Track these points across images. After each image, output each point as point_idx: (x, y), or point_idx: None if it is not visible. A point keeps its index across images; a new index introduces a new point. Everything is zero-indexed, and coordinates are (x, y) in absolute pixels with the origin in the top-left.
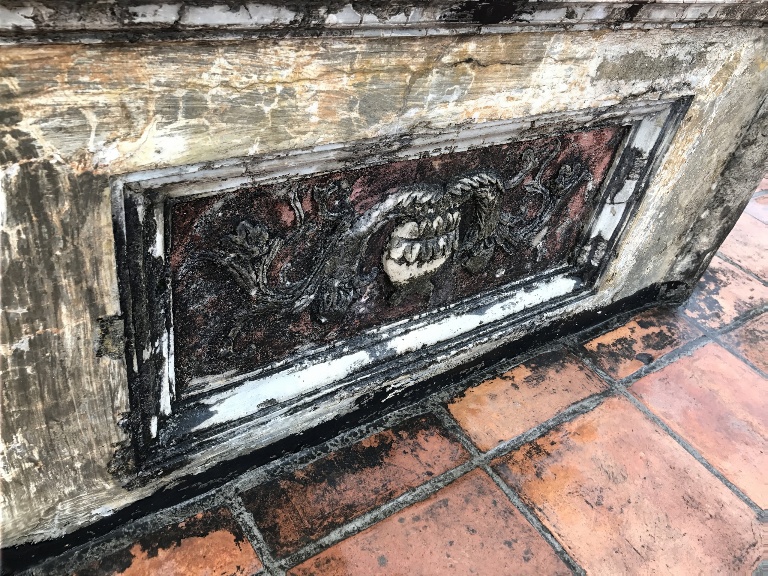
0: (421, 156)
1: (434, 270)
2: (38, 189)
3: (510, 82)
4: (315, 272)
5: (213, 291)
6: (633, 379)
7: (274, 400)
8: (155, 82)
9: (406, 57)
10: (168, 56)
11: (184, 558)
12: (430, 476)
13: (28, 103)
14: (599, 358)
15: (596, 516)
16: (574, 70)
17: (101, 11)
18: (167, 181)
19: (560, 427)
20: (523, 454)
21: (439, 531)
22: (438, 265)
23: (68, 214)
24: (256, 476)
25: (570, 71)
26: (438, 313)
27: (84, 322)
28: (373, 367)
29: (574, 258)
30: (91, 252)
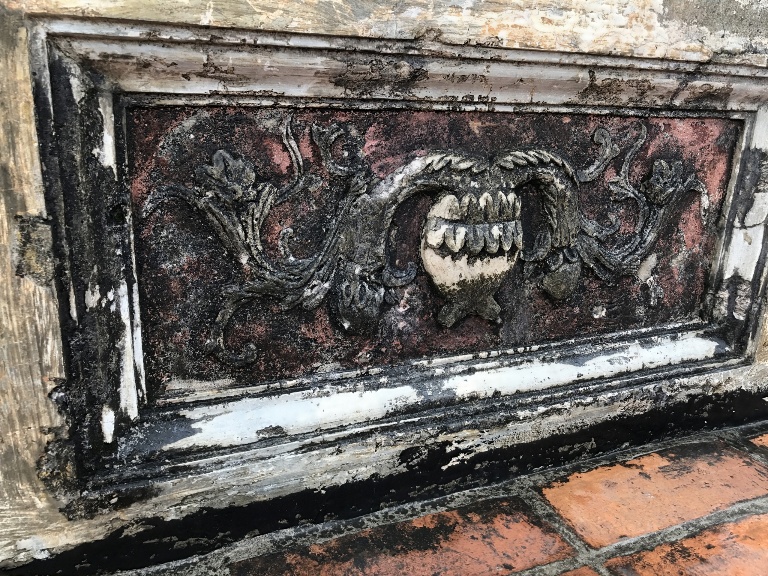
0: (450, 107)
1: (495, 277)
2: None
3: None
4: (327, 248)
5: (191, 247)
6: None
7: (281, 429)
8: None
9: None
10: None
11: None
12: (508, 570)
13: None
14: None
15: None
16: None
17: None
18: (106, 50)
19: (720, 527)
20: (660, 556)
21: None
22: (499, 271)
23: None
24: (257, 546)
25: None
26: (515, 355)
27: None
28: (423, 410)
29: (708, 310)
30: (5, 114)
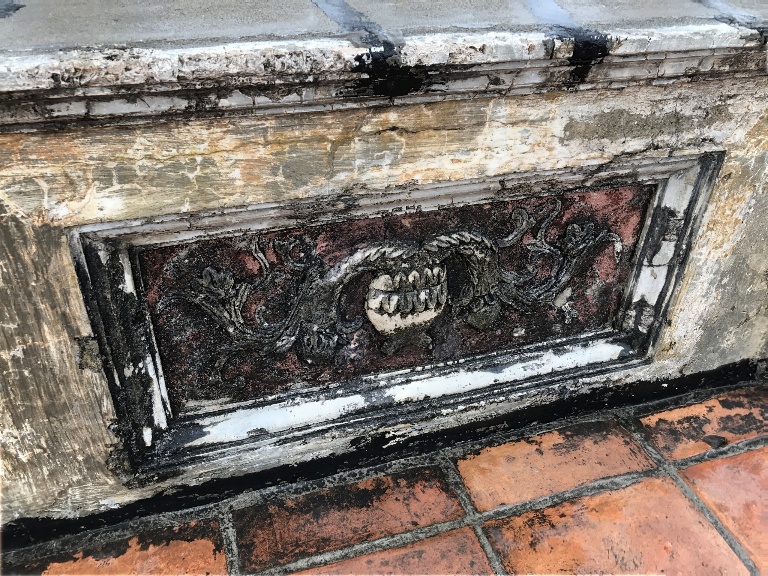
0: (384, 214)
1: (424, 323)
2: (10, 236)
3: (451, 146)
4: (291, 316)
5: (193, 326)
6: (690, 462)
7: (264, 430)
8: (89, 157)
9: (321, 129)
10: (96, 138)
11: (167, 556)
12: (414, 526)
13: None
14: (654, 435)
15: None
16: (532, 132)
17: (26, 110)
18: (120, 232)
19: (577, 500)
20: (523, 521)
21: None
22: (428, 318)
23: (36, 255)
24: (251, 498)
25: (527, 133)
26: (445, 367)
27: (64, 339)
28: (369, 412)
29: (618, 323)
30: (60, 285)
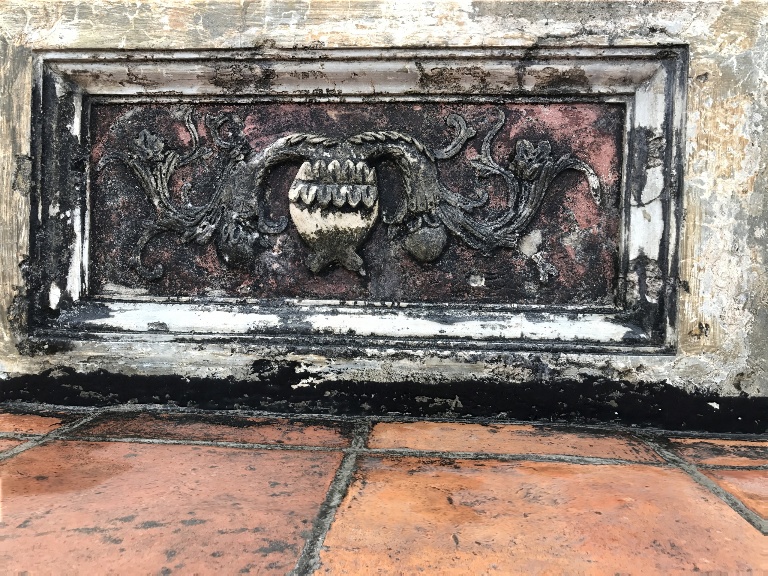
0: (307, 100)
1: (350, 231)
2: None
3: (355, 12)
4: (214, 199)
5: (125, 193)
6: (730, 468)
7: (166, 326)
8: None
9: None
10: None
11: (12, 418)
12: (277, 442)
13: (1, 4)
14: (683, 447)
15: (443, 508)
16: (437, 4)
17: None
18: (75, 69)
19: (513, 460)
20: (420, 460)
21: (218, 460)
22: (354, 226)
23: (9, 71)
24: (132, 409)
25: (432, 5)
26: (383, 307)
27: (8, 155)
28: (281, 334)
29: (620, 295)
30: (18, 101)
